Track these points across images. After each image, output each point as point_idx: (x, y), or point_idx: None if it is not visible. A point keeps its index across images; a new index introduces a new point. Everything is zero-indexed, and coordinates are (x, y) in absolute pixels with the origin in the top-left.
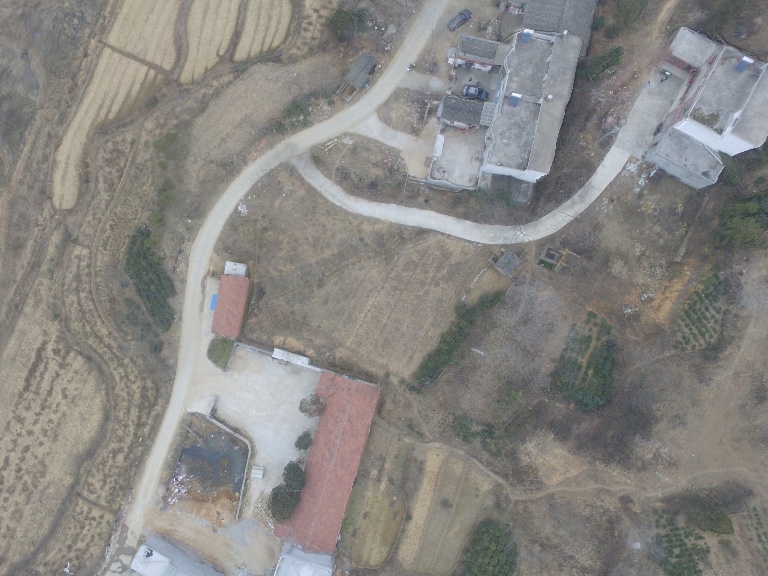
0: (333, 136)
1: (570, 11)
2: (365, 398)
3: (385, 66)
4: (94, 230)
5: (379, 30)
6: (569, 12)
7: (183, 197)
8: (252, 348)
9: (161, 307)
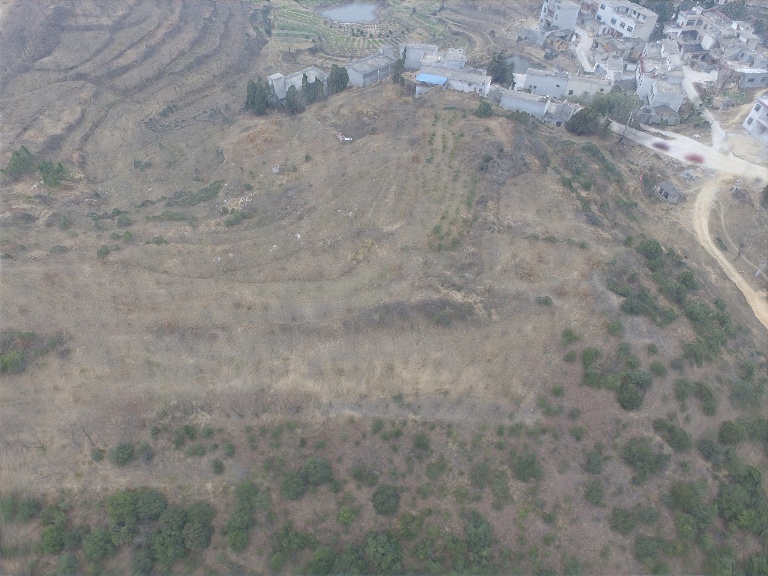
0: None
1: None
2: None
3: None
4: None
5: None
6: None
7: None
8: None
9: None
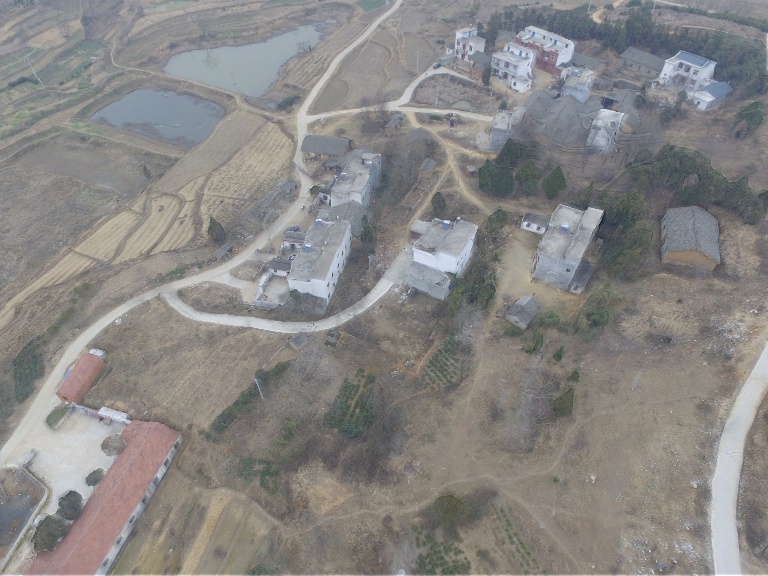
0: (197, 283)
1: (351, 217)
2: (162, 438)
3: (241, 250)
4: (6, 340)
5: (244, 239)
6: (350, 218)
7: (80, 317)
8: (85, 409)
9: (27, 384)
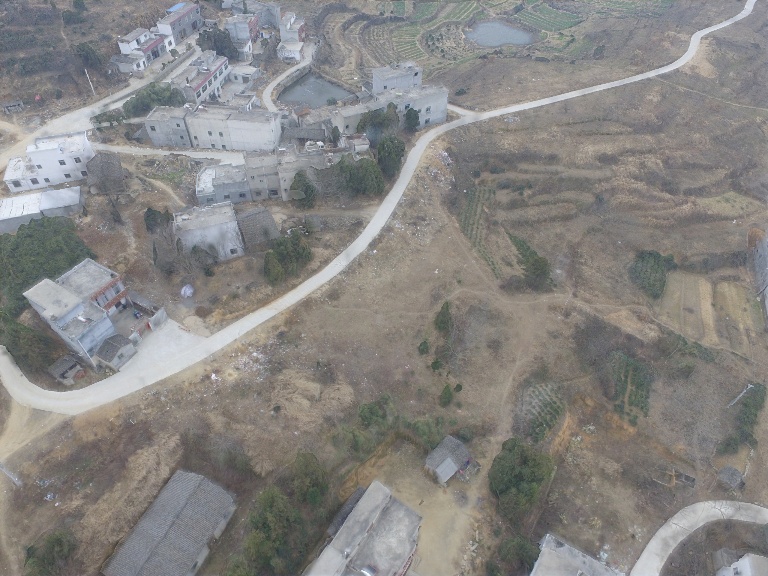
0: None
1: None
2: None
3: None
4: None
5: None
6: None
7: None
8: None
9: None
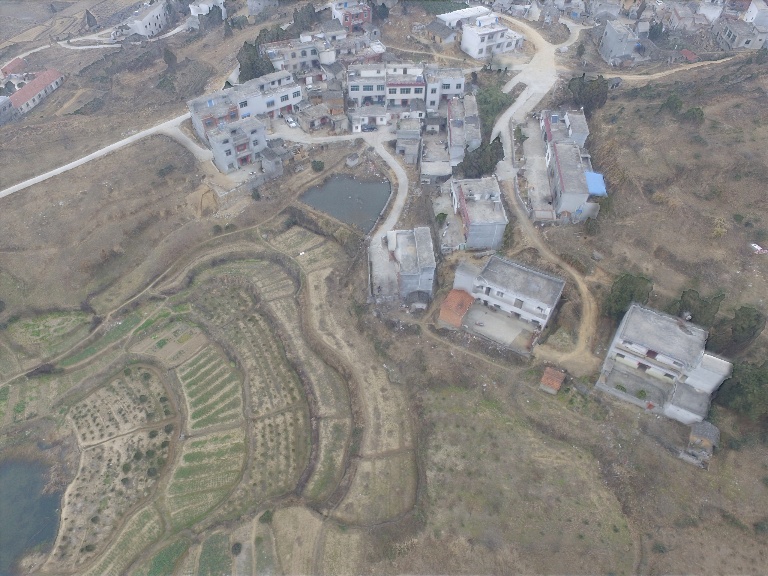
0: None
1: None
2: (54, 73)
3: (106, 29)
4: None
5: None
6: None
7: None
8: (16, 75)
9: None
